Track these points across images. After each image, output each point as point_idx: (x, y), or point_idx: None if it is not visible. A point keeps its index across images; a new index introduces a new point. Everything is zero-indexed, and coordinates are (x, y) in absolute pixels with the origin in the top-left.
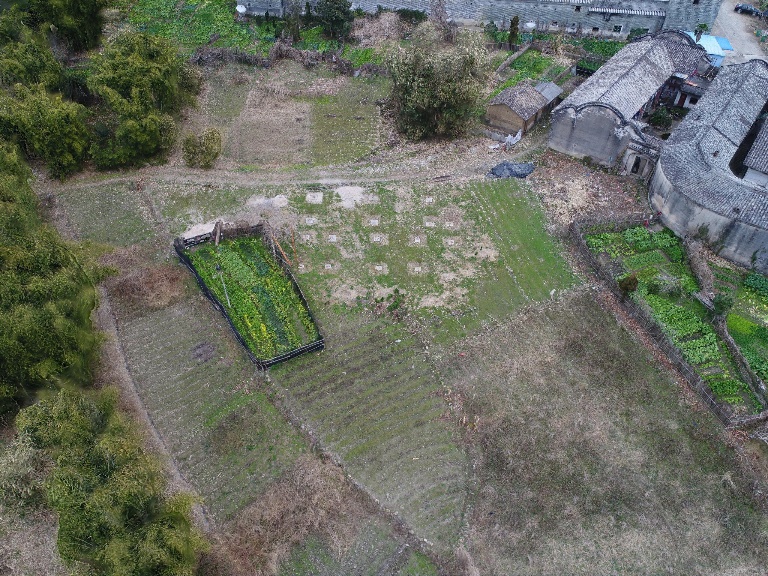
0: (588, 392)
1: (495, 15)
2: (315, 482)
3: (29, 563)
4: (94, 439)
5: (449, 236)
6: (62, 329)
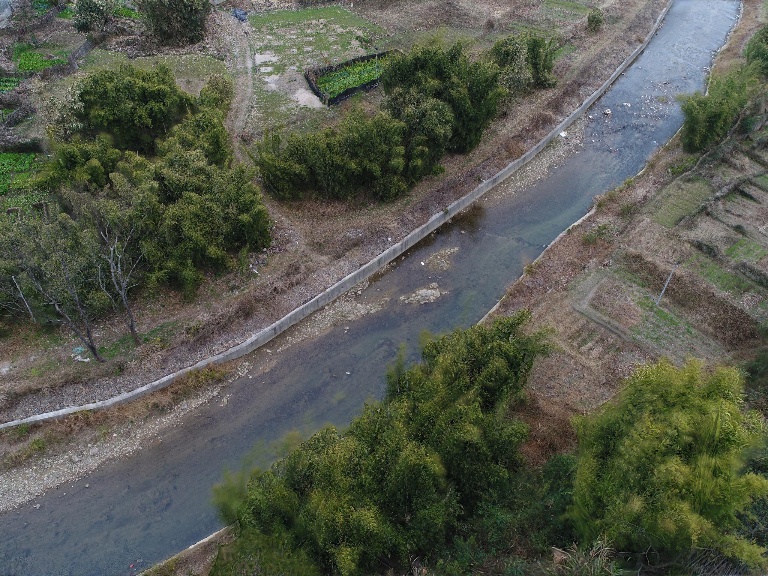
0: (404, 7)
1: (3, 4)
2: None
3: (529, 112)
4: None
5: None
6: None
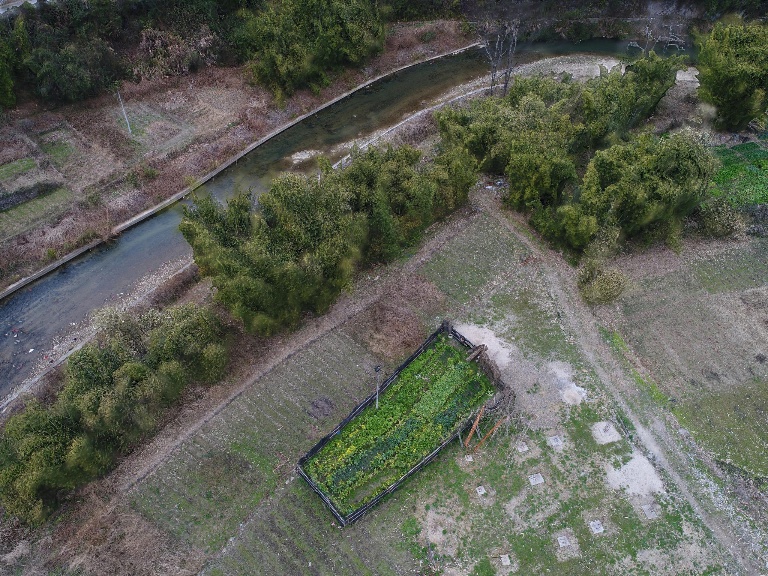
0: None
1: None
2: (163, 575)
3: None
4: (163, 360)
5: None
6: (244, 285)
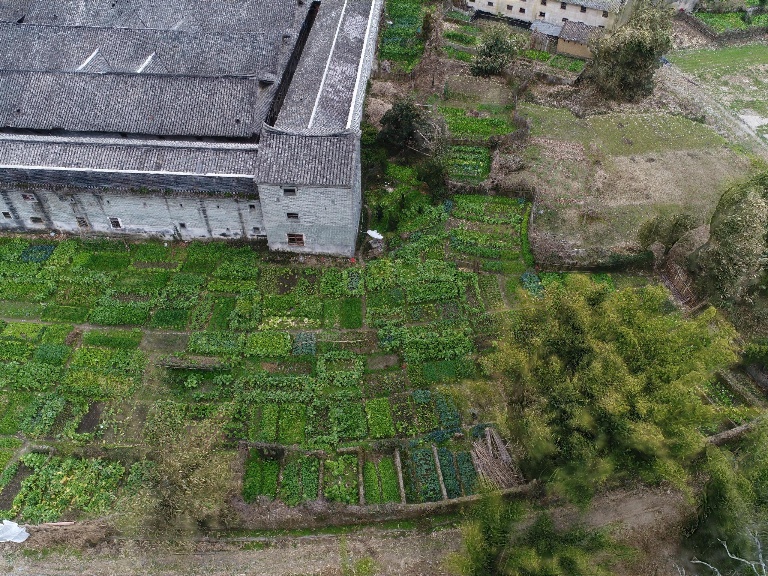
0: None
1: None
2: None
3: None
4: None
5: (760, 81)
6: None
